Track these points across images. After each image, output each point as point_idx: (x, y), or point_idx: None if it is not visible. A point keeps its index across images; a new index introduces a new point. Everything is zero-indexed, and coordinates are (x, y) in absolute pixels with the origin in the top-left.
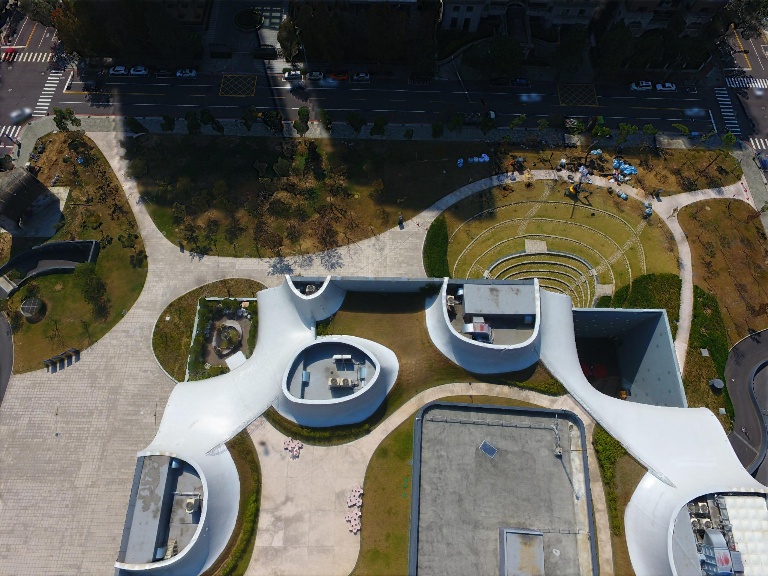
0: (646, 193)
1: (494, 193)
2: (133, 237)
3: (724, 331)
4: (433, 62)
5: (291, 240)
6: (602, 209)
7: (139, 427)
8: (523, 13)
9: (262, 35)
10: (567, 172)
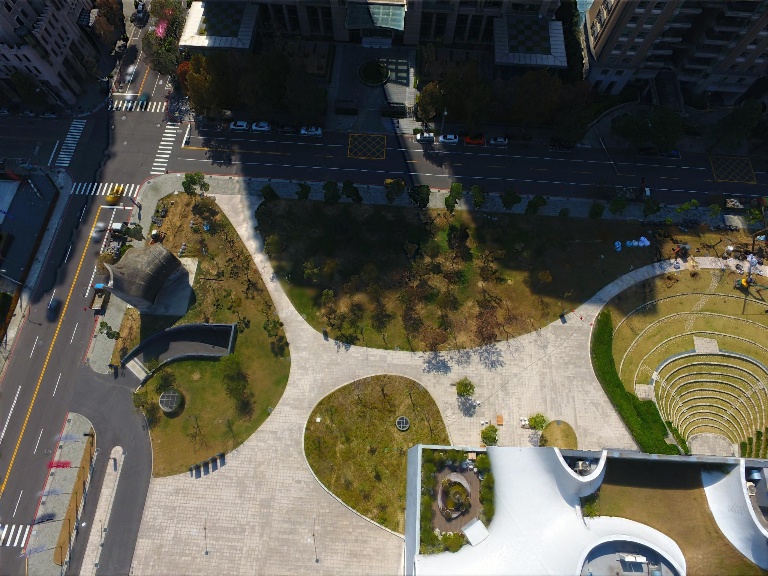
0: None
1: (658, 283)
2: (278, 325)
3: None
4: None
5: (444, 331)
6: None
7: (297, 549)
8: (674, 78)
9: (389, 90)
10: (734, 261)
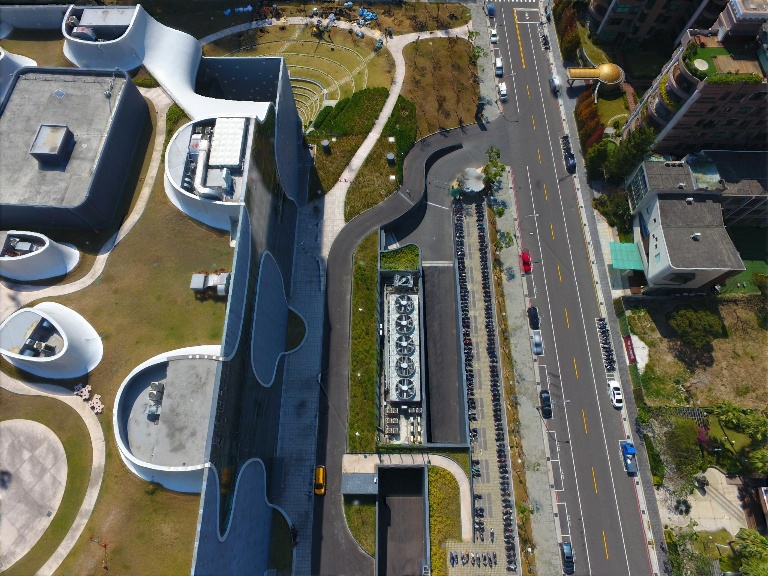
0: (381, 33)
1: (251, 33)
2: None
3: (414, 126)
4: None
5: None
6: (341, 45)
7: None
8: None
9: None
10: (318, 18)
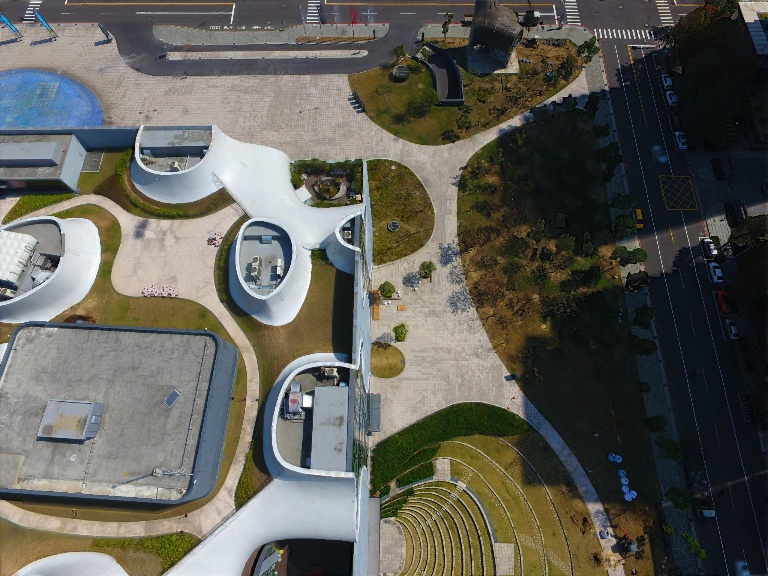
0: None
1: (575, 503)
2: (467, 126)
3: None
4: None
5: None
6: None
7: None
8: None
9: (764, 208)
10: None
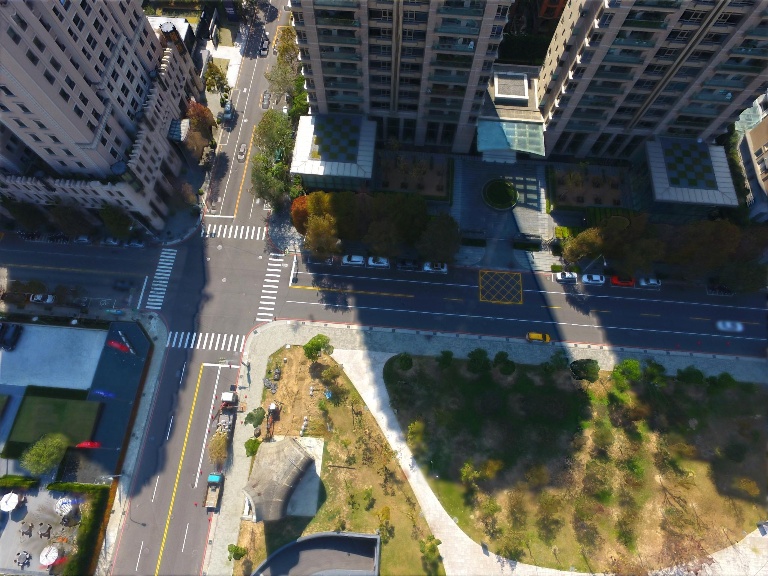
0: None
1: None
2: (435, 543)
3: None
4: (764, 286)
5: (625, 545)
6: None
7: None
8: None
9: (518, 216)
10: None
